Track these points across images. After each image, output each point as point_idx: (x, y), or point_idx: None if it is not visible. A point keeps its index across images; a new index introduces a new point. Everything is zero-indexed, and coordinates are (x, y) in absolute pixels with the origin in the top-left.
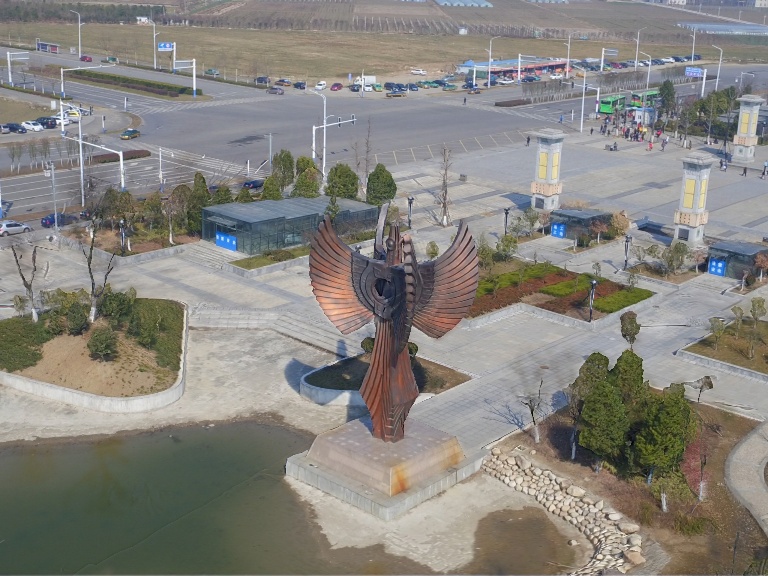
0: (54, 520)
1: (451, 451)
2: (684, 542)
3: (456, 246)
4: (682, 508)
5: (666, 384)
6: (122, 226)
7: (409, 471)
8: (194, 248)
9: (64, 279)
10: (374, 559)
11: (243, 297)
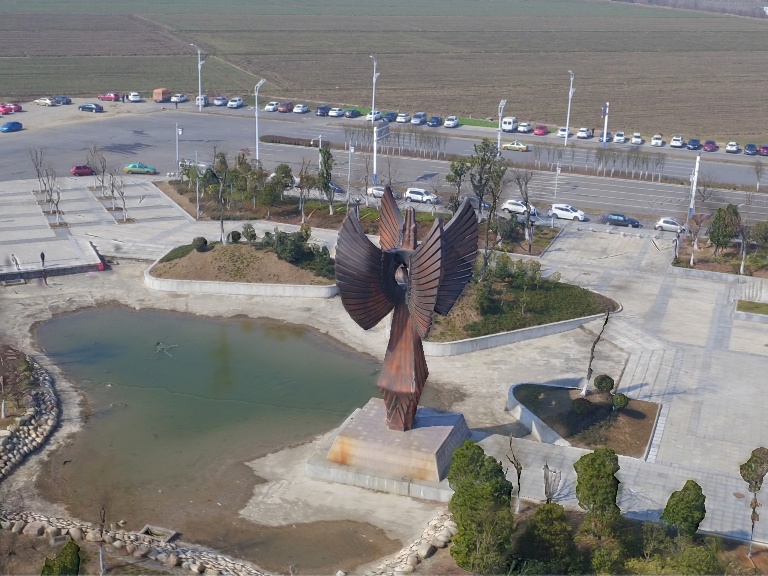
0: (220, 367)
1: (422, 464)
2: None
3: (425, 242)
4: None
5: None
6: (678, 235)
7: (358, 451)
8: (755, 283)
9: (600, 265)
10: (241, 482)
11: (678, 326)
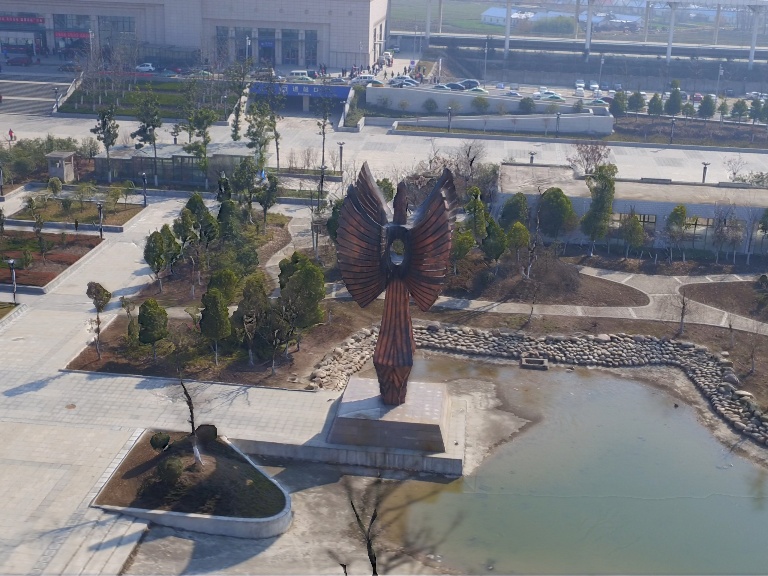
0: (705, 549)
1: None
2: (363, 317)
3: None
4: (325, 317)
5: (64, 352)
6: None
7: None
8: None
9: None
10: (517, 405)
11: None
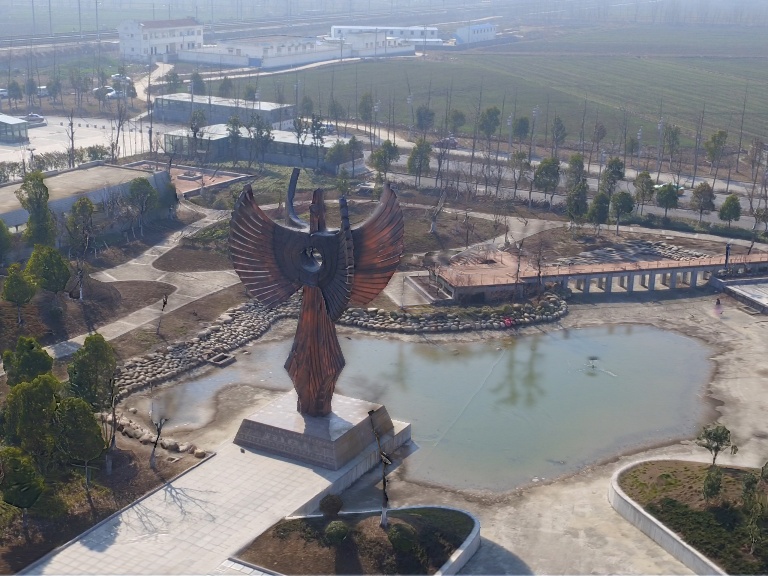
0: (560, 391)
1: None
2: None
3: None
4: None
5: None
6: None
7: None
8: None
9: None
10: None
11: None
